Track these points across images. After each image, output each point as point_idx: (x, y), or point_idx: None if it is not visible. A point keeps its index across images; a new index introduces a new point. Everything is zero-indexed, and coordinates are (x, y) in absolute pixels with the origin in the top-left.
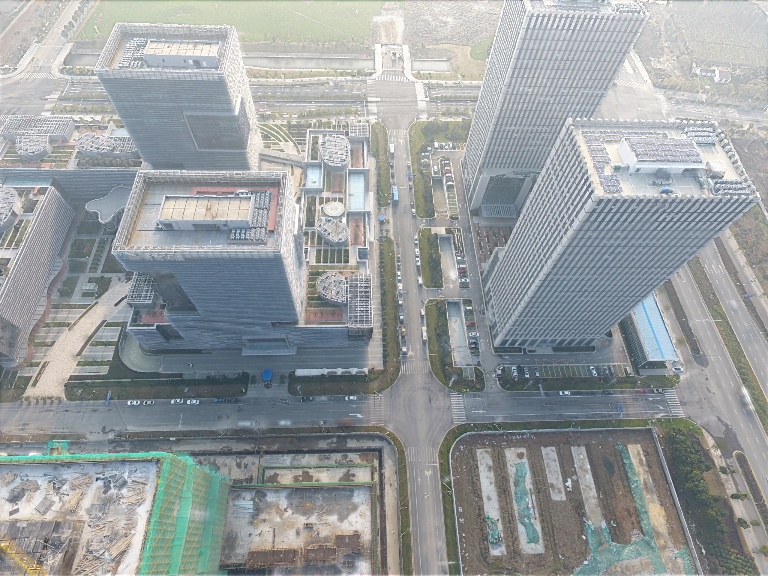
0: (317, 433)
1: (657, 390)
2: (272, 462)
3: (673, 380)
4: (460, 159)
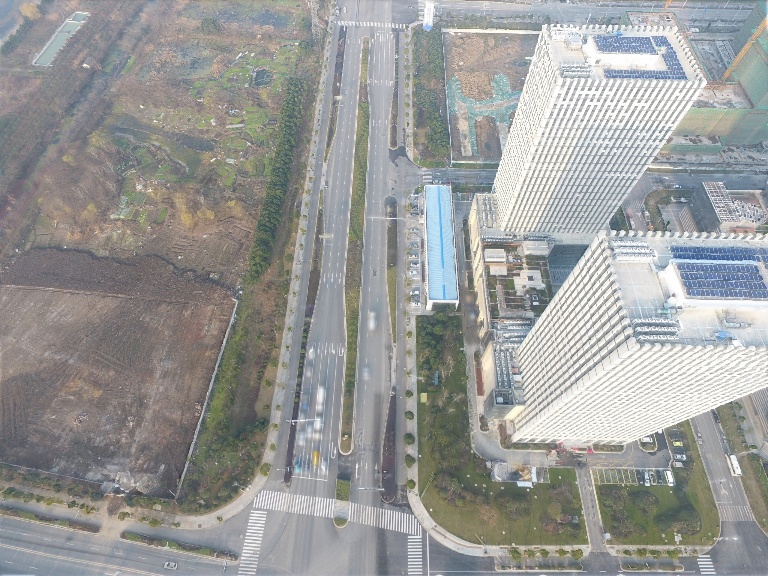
0: (693, 168)
1: (439, 182)
2: (715, 158)
3: (422, 189)
4: (627, 449)
